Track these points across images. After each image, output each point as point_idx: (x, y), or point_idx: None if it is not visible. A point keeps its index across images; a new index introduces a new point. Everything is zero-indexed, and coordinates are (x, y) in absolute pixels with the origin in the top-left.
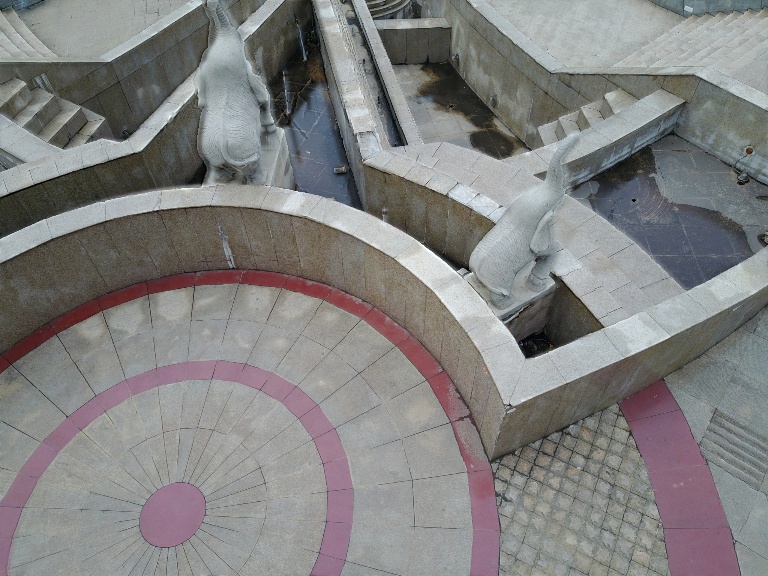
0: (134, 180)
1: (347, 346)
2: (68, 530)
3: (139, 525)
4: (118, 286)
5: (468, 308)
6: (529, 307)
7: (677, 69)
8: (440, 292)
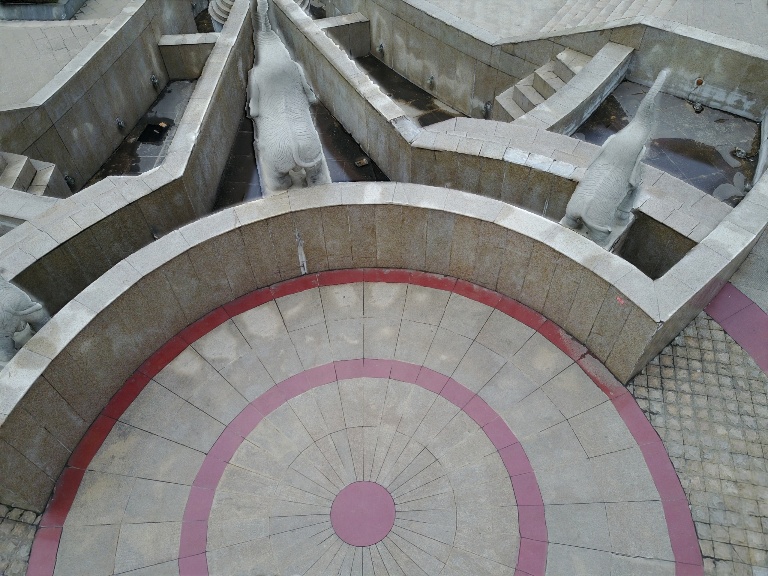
0: (175, 208)
1: (451, 319)
2: (265, 559)
3: (335, 533)
4: (196, 317)
5: (582, 250)
6: (618, 241)
7: (620, 21)
8: (550, 242)
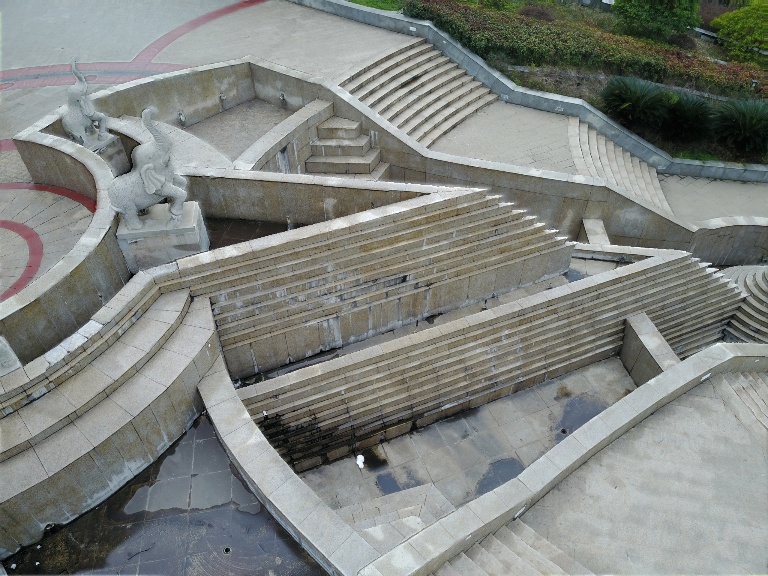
0: None
1: None
2: None
3: None
4: None
5: None
6: None
7: (400, 568)
8: None
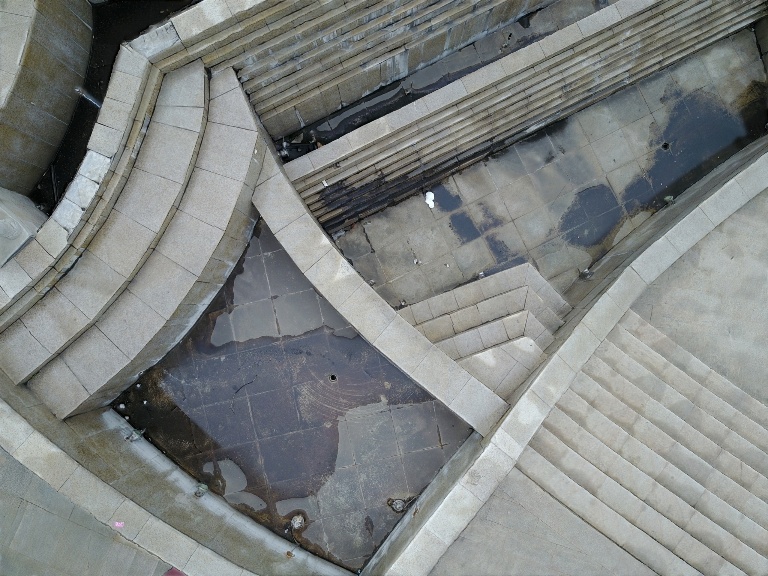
0: None
1: None
2: None
3: None
4: None
5: None
6: None
7: (528, 425)
8: None
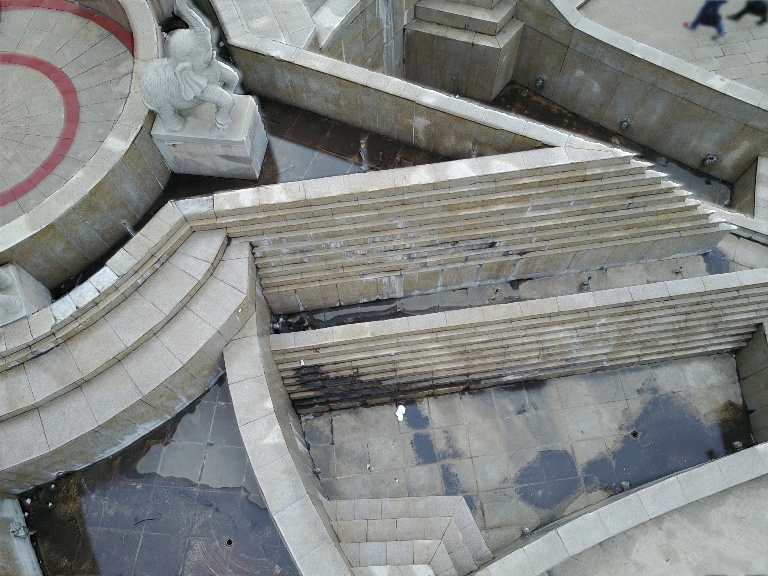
0: None
1: None
2: None
3: None
4: None
5: None
6: None
7: None
8: None
